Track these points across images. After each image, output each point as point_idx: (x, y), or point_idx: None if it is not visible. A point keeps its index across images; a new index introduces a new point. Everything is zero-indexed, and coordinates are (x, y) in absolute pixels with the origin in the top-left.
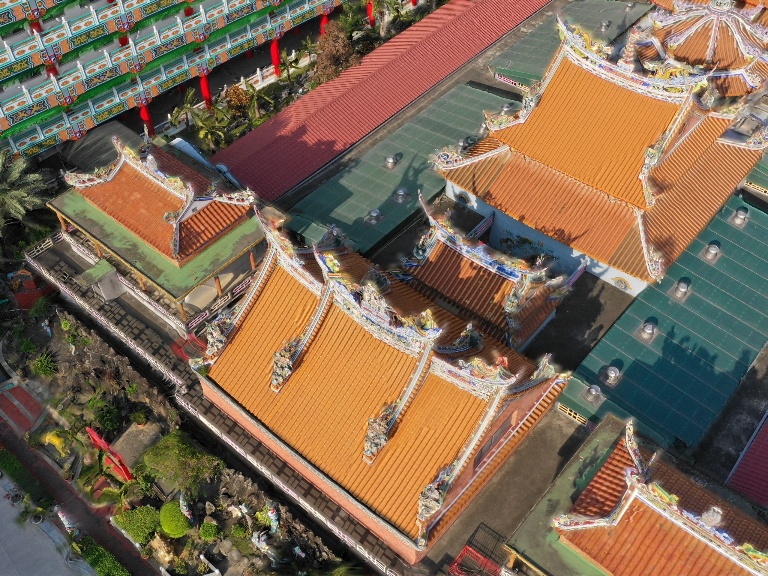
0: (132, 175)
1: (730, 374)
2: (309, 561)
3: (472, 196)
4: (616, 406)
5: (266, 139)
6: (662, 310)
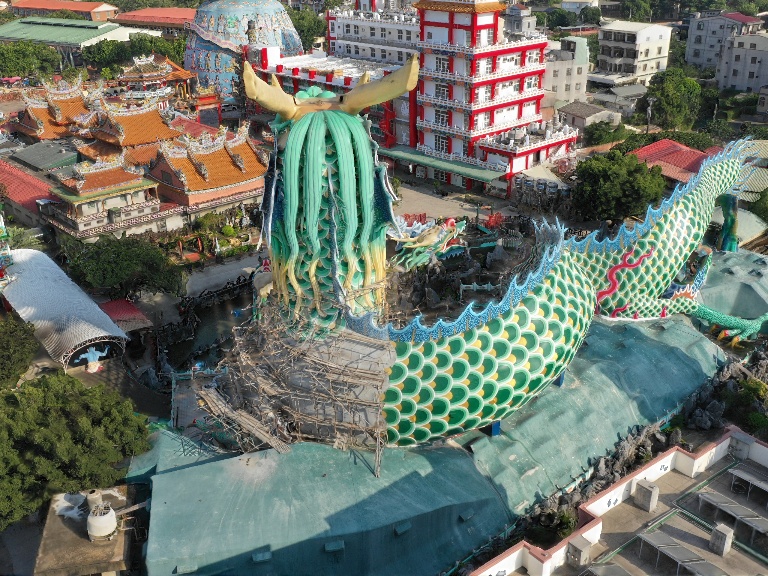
0: (90, 175)
1: None
2: None
3: (133, 168)
4: None
5: (47, 198)
6: None
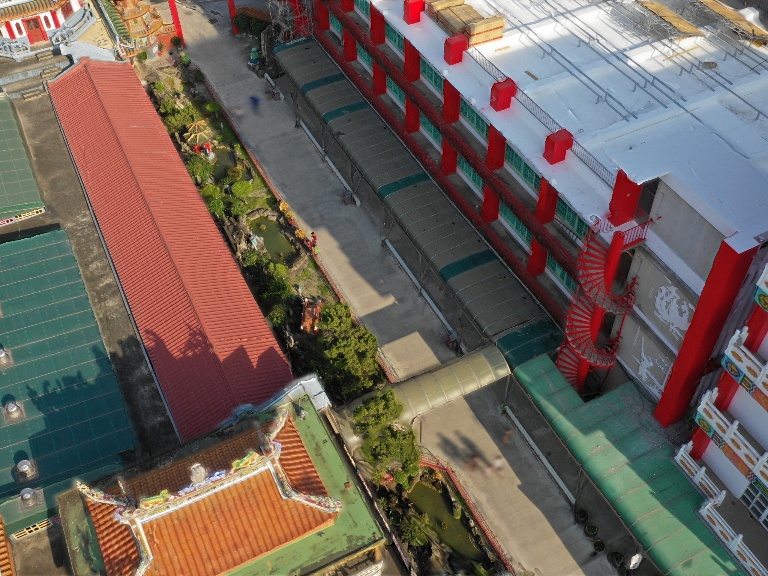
0: None
1: (102, 374)
2: None
3: None
4: (56, 485)
5: None
6: (5, 385)
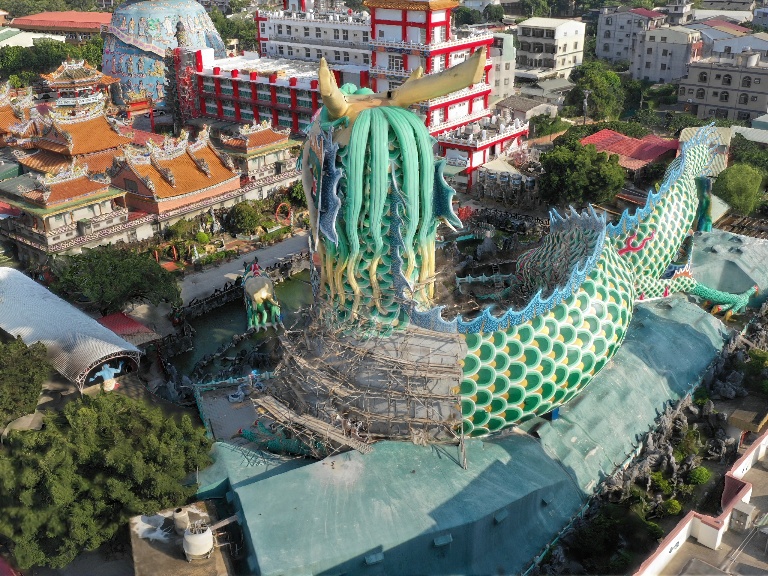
0: (54, 186)
1: None
2: (229, 215)
3: None
4: None
5: (1, 213)
6: None
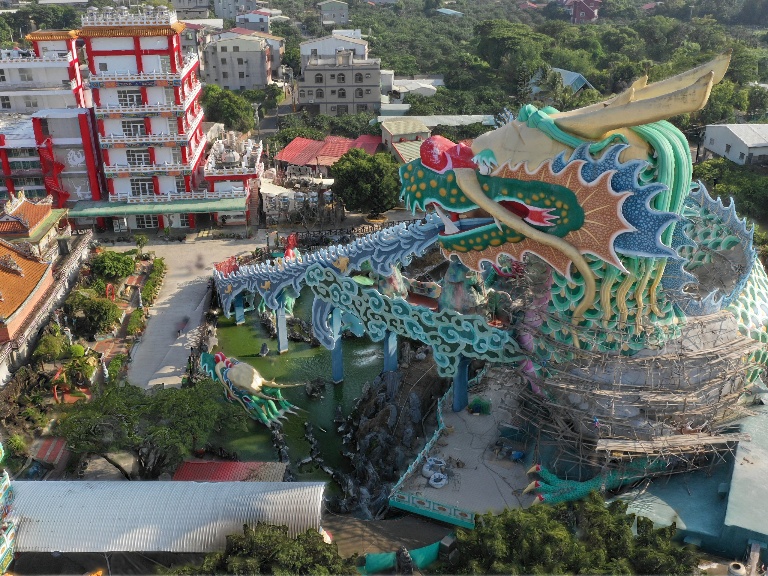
0: None
1: None
2: None
3: None
4: None
5: None
6: None
